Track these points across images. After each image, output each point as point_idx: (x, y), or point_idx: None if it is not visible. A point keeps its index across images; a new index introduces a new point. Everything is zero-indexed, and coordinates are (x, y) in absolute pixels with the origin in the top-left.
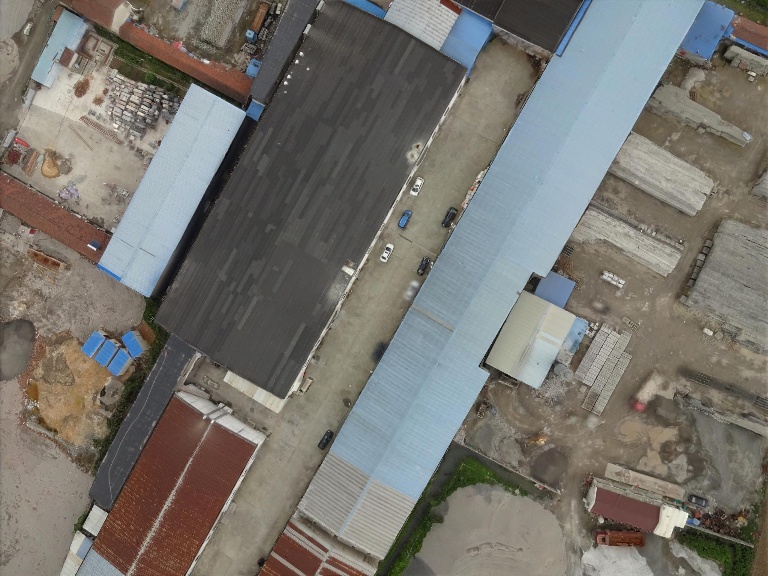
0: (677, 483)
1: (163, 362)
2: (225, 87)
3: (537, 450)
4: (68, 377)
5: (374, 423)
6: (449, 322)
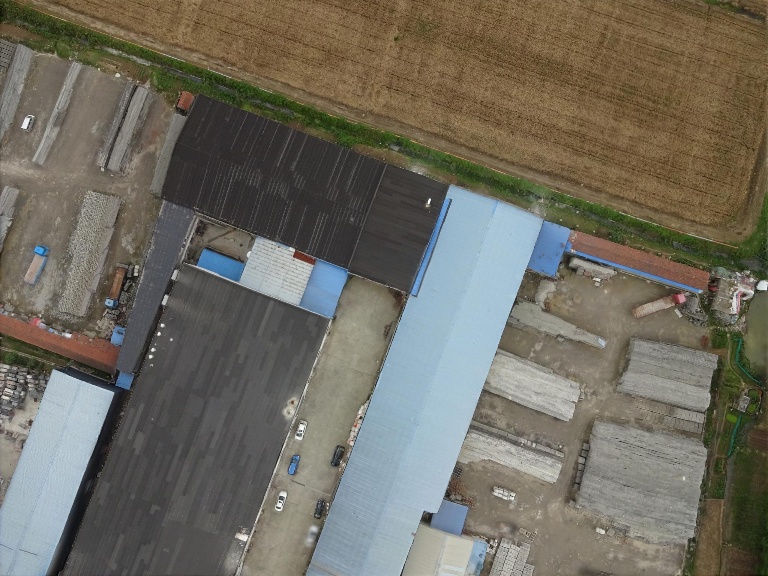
0: None
1: None
2: (91, 360)
3: None
4: None
5: None
6: (350, 575)
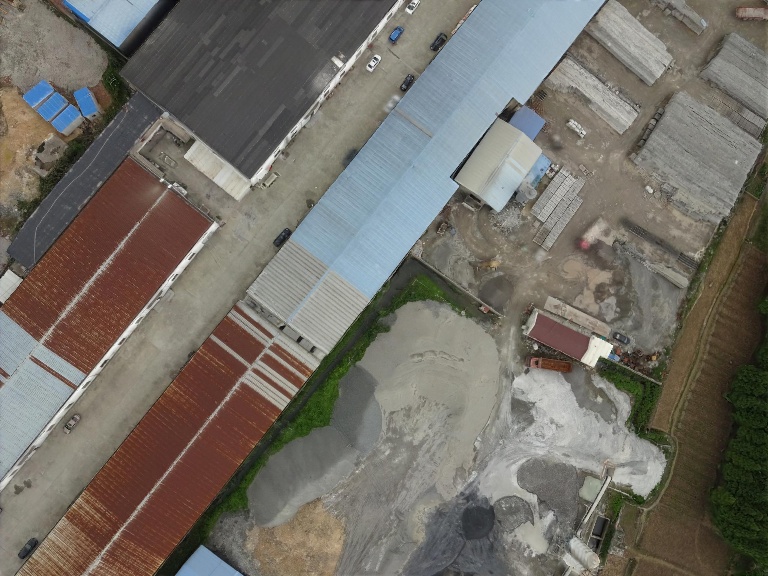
0: (605, 322)
1: (121, 120)
2: None
3: (487, 275)
4: (1, 125)
5: (340, 215)
6: (429, 128)
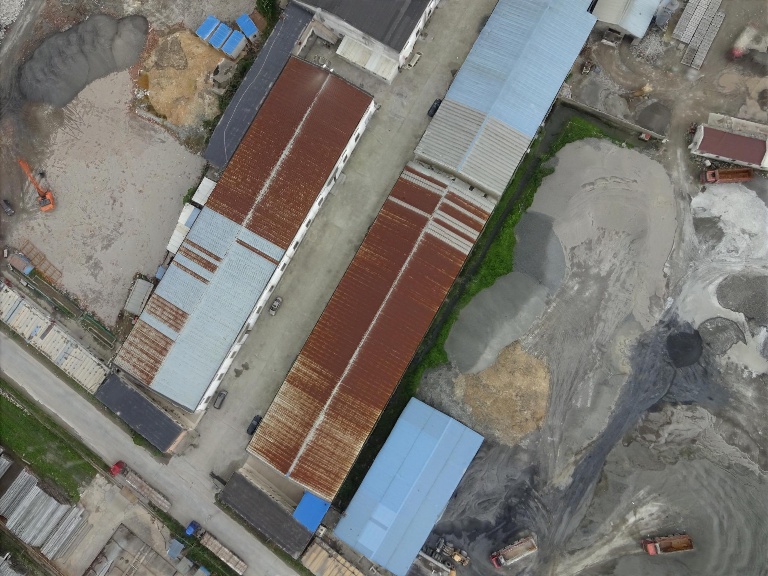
0: None
1: (281, 28)
2: None
3: (641, 105)
4: (181, 60)
5: (489, 66)
6: None
